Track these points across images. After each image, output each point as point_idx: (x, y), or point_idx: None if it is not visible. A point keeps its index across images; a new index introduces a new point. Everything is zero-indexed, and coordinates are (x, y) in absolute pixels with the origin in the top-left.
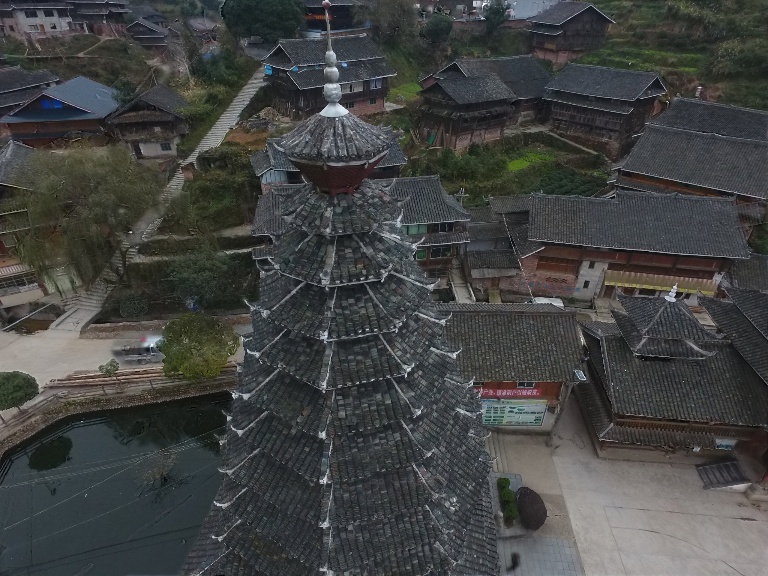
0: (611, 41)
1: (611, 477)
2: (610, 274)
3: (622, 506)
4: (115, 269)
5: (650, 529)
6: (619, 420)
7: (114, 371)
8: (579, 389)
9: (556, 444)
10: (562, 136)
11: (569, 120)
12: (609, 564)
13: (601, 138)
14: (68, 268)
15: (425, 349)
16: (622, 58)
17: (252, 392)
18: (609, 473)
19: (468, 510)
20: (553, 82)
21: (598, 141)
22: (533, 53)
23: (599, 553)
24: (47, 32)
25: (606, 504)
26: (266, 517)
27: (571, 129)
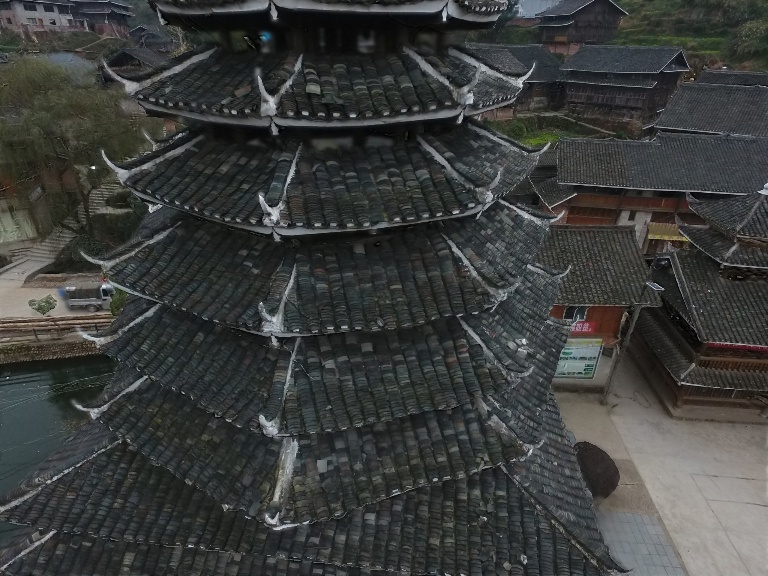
0: (625, 31)
1: (693, 440)
2: (654, 226)
3: (716, 474)
4: (73, 213)
5: (762, 503)
6: (703, 358)
7: (49, 308)
8: (633, 344)
9: (613, 402)
10: (578, 120)
11: (586, 102)
12: (714, 547)
13: (621, 118)
14: (11, 197)
15: (477, 3)
16: (638, 45)
17: (144, 82)
18: (689, 435)
19: (540, 385)
20: (568, 63)
21: (618, 122)
22: (543, 44)
23: (697, 533)
24: (45, 25)
25: (693, 471)
26: (172, 357)
27: (588, 112)
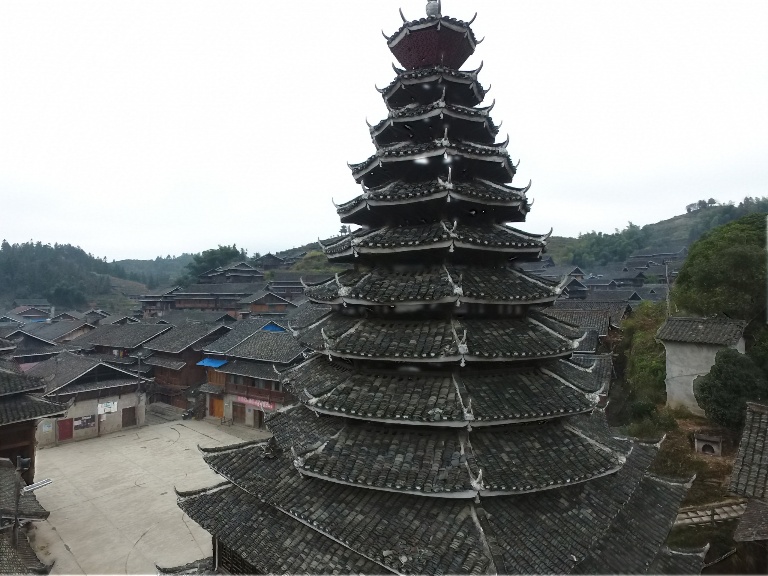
0: None
1: None
2: None
3: None
4: None
5: None
6: None
7: None
8: None
9: None
10: None
11: None
12: None
13: None
14: None
15: None
16: None
17: None
18: None
19: None
20: None
21: None
22: None
23: None
24: None
25: None
26: None
27: None
